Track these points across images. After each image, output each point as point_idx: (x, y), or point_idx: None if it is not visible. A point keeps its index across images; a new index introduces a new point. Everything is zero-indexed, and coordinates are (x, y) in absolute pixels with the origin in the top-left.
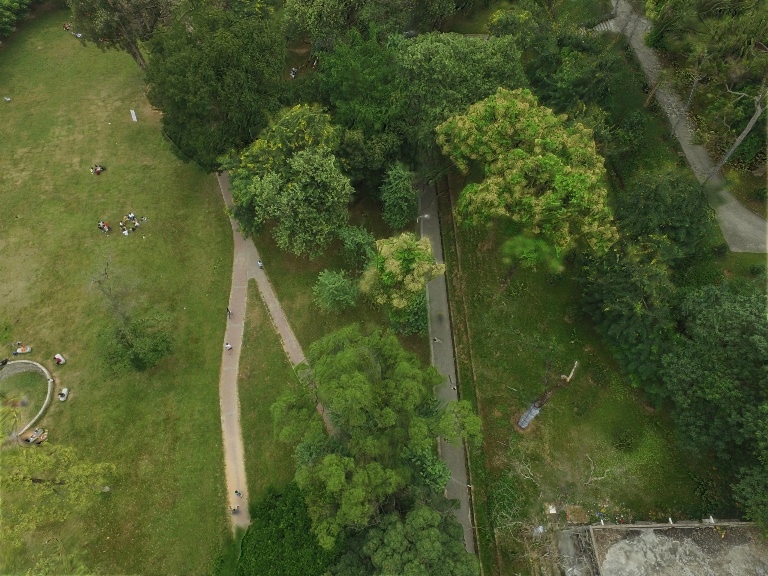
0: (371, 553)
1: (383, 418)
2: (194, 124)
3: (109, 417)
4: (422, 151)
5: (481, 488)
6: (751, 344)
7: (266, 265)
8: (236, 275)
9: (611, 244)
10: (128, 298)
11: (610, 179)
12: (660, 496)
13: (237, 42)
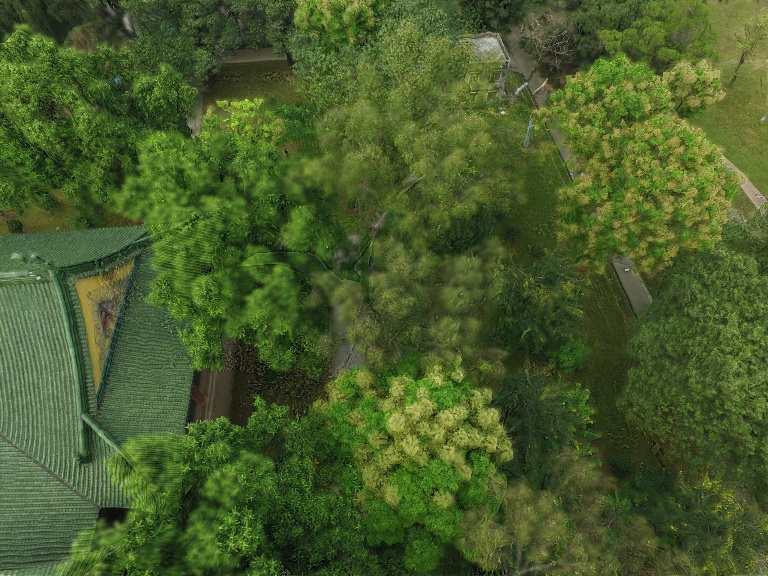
0: None
1: None
2: None
3: None
4: None
5: None
6: None
7: None
8: None
9: None
10: None
11: None
12: None
13: None
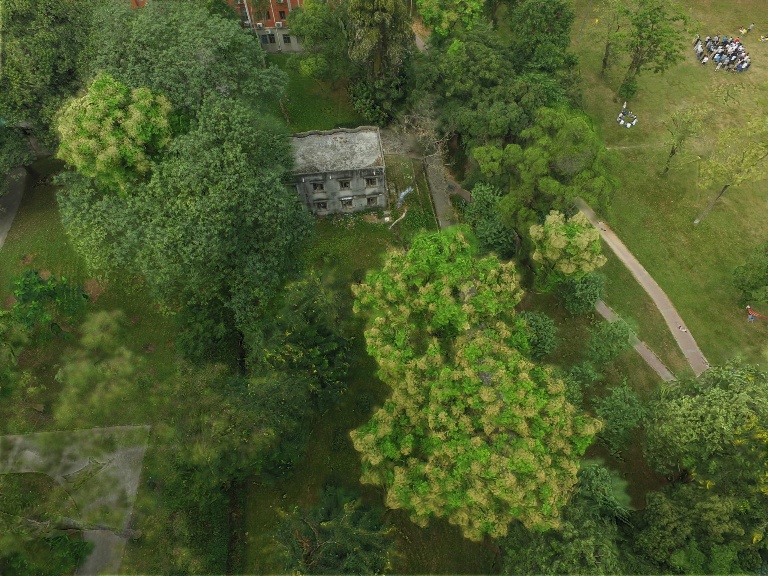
0: None
1: None
2: None
3: (738, 264)
4: None
5: None
6: None
7: None
8: None
9: None
10: None
11: None
12: None
13: None
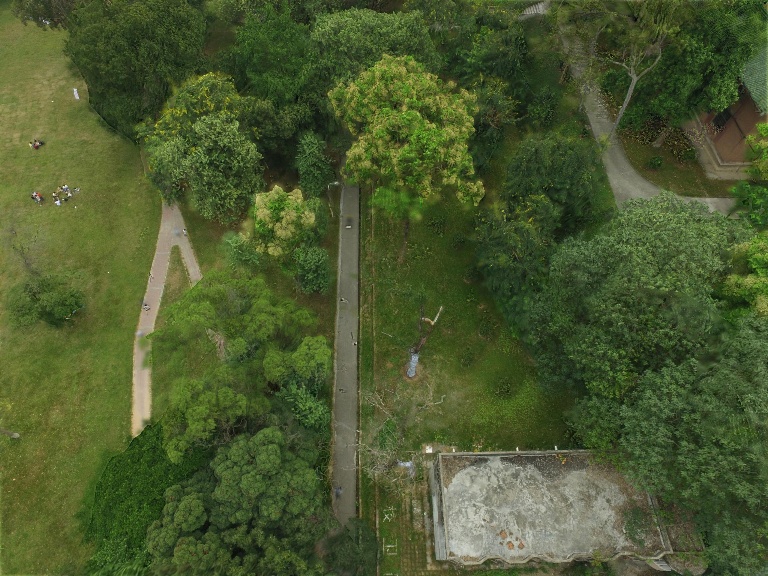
0: (216, 467)
1: (235, 347)
2: (113, 94)
3: (25, 371)
4: (331, 121)
5: (368, 433)
6: (582, 282)
7: (191, 233)
8: (161, 242)
9: (479, 199)
10: (55, 263)
11: None
12: (531, 437)
13: (152, 15)
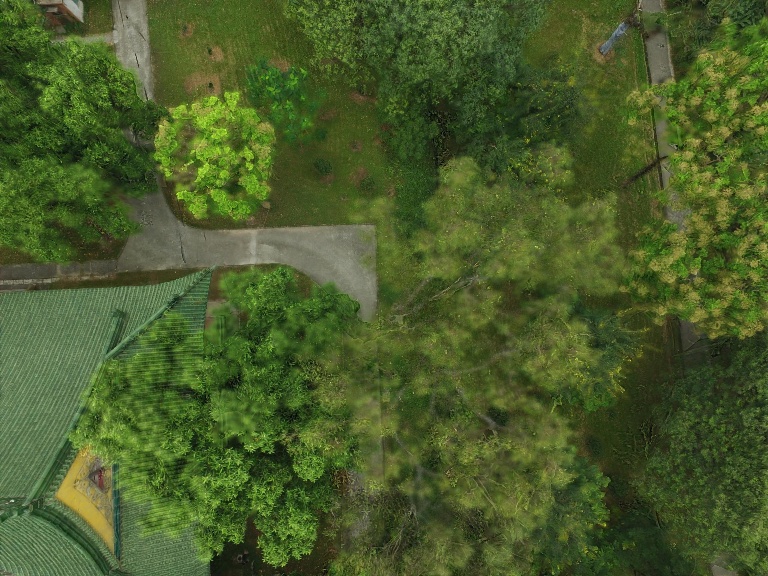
0: None
1: None
2: None
3: None
4: None
5: (632, 7)
6: None
7: None
8: None
9: None
10: None
11: (463, 381)
12: None
13: None
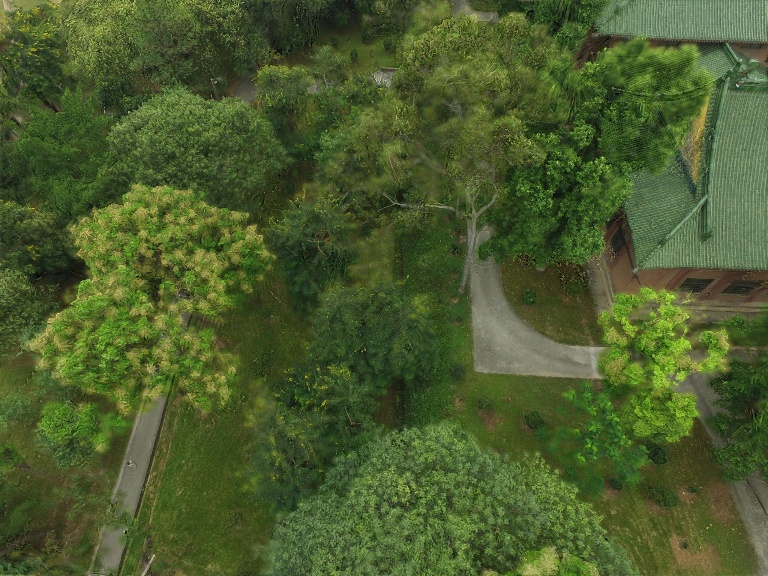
0: None
1: None
2: None
3: None
4: None
5: None
6: None
7: None
8: None
9: (226, 396)
10: None
11: (394, 261)
12: None
13: None
